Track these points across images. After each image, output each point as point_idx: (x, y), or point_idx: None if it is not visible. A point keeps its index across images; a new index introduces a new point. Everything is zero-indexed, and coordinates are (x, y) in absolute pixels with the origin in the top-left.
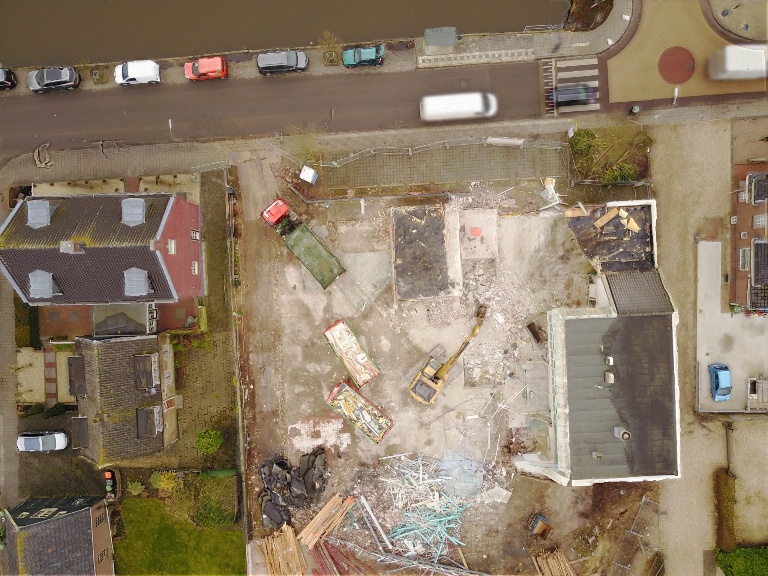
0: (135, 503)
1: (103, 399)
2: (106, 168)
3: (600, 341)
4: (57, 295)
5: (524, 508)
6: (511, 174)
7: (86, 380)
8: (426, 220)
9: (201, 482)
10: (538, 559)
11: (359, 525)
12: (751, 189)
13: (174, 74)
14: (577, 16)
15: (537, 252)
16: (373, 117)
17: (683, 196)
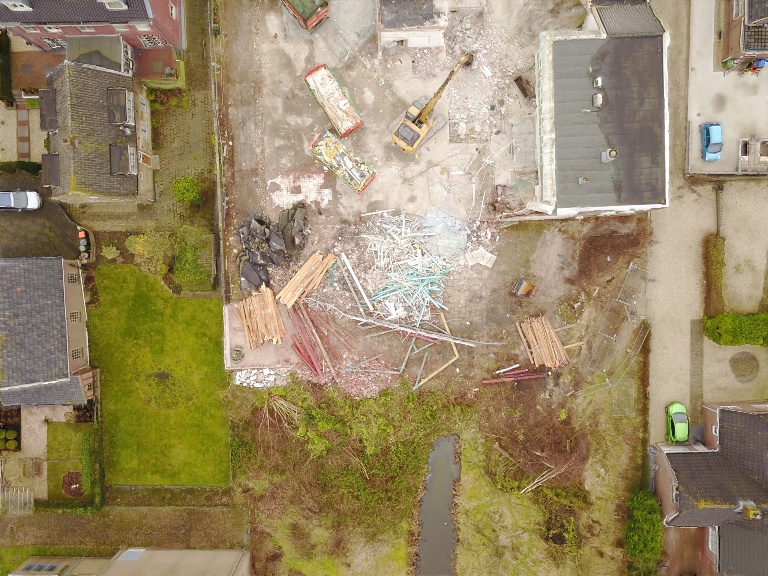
0: (110, 269)
1: (74, 124)
2: None
3: (588, 63)
4: (27, 11)
5: (509, 273)
6: None
7: (57, 112)
8: None
9: None
10: (522, 325)
11: (339, 285)
12: None
13: None
14: None
15: (526, 5)
16: None
17: None
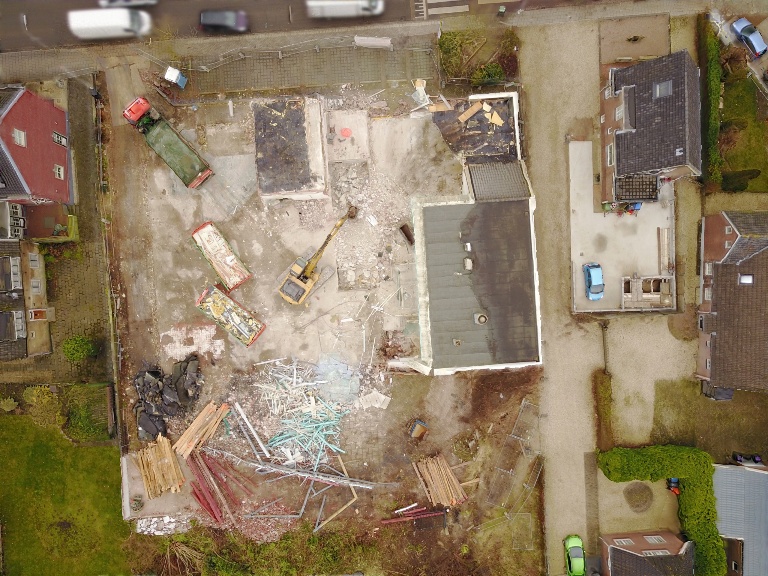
0: (8, 420)
1: None
2: None
3: (459, 228)
4: None
5: (403, 414)
6: (382, 76)
7: None
8: (286, 113)
9: None
10: (418, 465)
11: (235, 434)
12: (612, 81)
13: None
14: None
15: (410, 154)
16: (243, 21)
17: (553, 96)
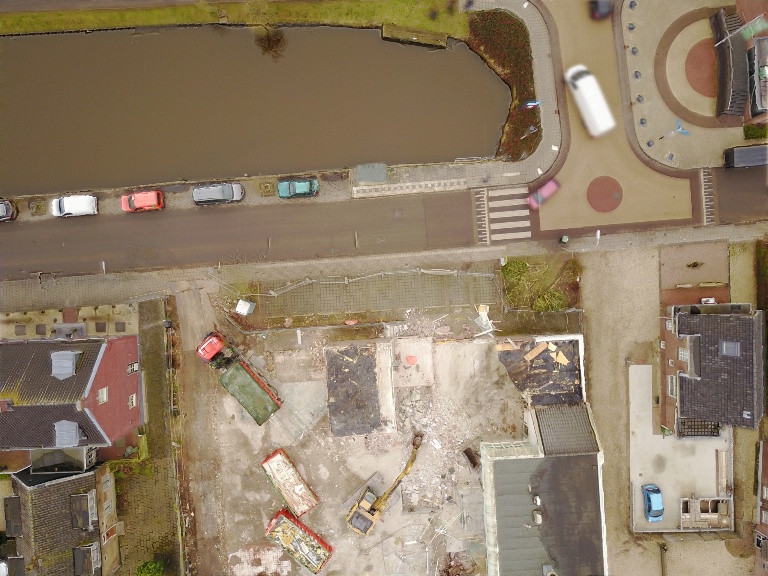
0: None
1: (37, 544)
2: (45, 299)
3: (528, 481)
4: None
5: None
6: (446, 301)
7: (22, 521)
8: (358, 359)
9: None
10: None
11: None
12: (676, 322)
13: (112, 205)
14: (508, 146)
15: (472, 377)
16: (309, 246)
17: (614, 321)
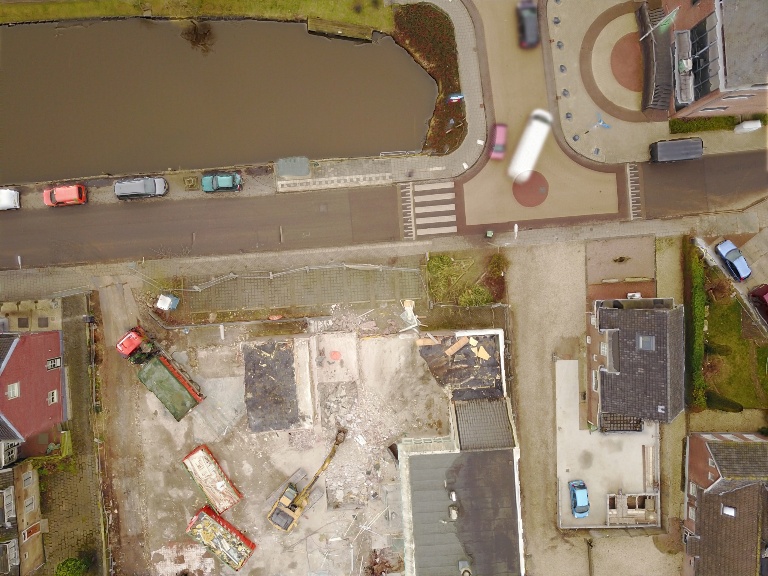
0: None
1: None
2: None
3: (444, 476)
4: None
5: None
6: (371, 296)
7: None
8: (275, 354)
9: None
10: None
11: None
12: (597, 316)
13: (34, 200)
14: (433, 141)
15: (398, 373)
16: (234, 241)
17: (540, 316)
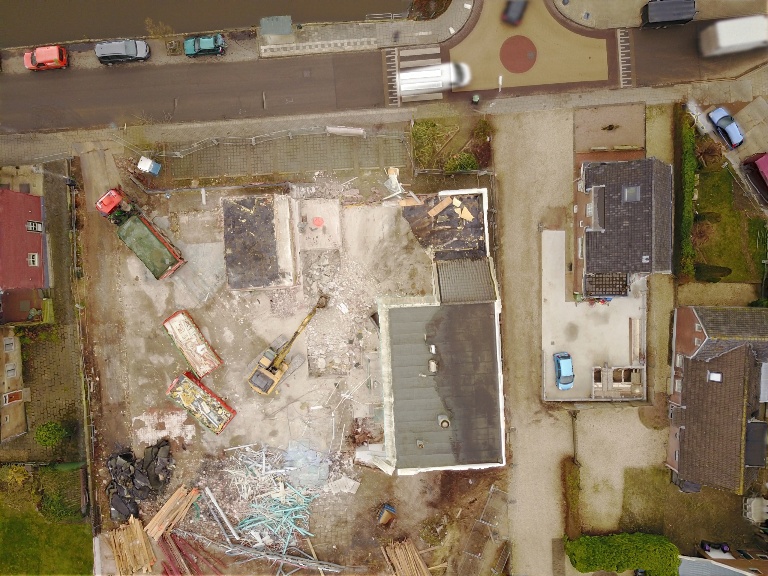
0: None
1: None
2: None
3: (424, 330)
4: None
5: (373, 498)
6: (355, 164)
7: None
8: (255, 210)
9: (42, 475)
10: (387, 549)
11: (205, 517)
12: (583, 177)
13: (15, 64)
14: (419, 5)
15: (381, 242)
16: (216, 107)
17: (526, 185)
